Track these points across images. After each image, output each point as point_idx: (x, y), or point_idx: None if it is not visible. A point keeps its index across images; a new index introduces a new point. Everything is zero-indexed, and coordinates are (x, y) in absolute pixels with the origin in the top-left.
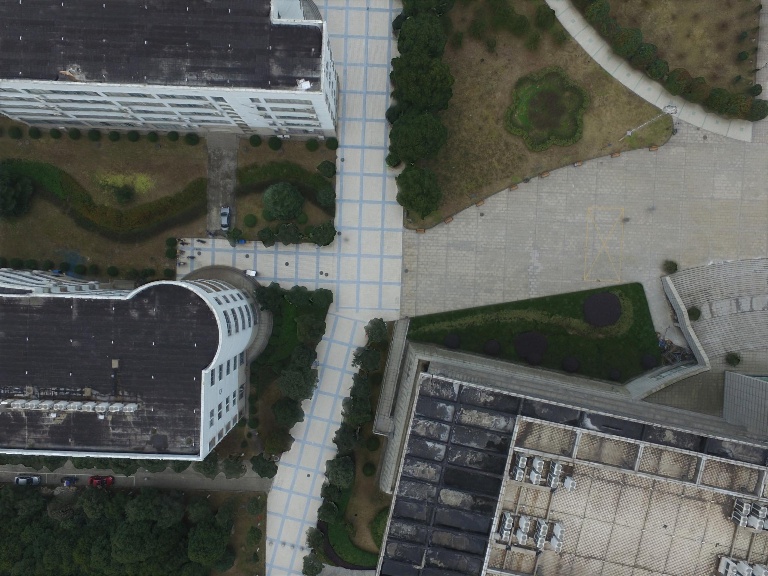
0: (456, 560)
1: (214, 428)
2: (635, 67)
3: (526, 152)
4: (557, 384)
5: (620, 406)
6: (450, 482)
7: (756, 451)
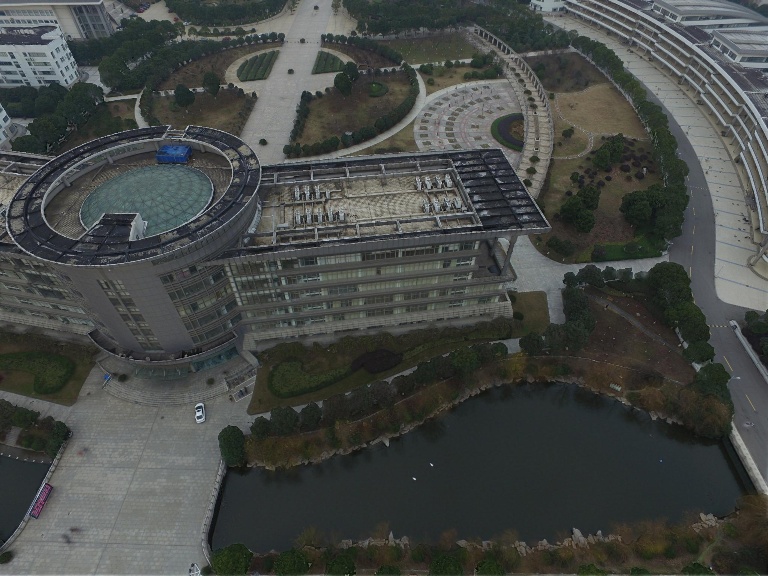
0: None
1: None
2: None
3: None
4: None
5: None
6: None
7: None
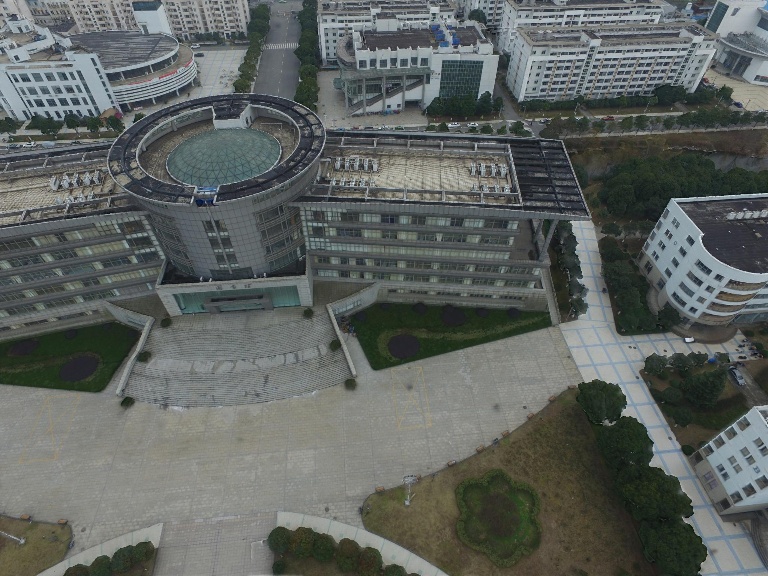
0: (526, 156)
1: (669, 222)
2: (420, 575)
3: (505, 469)
4: (439, 285)
5: (414, 258)
6: (545, 181)
7: None
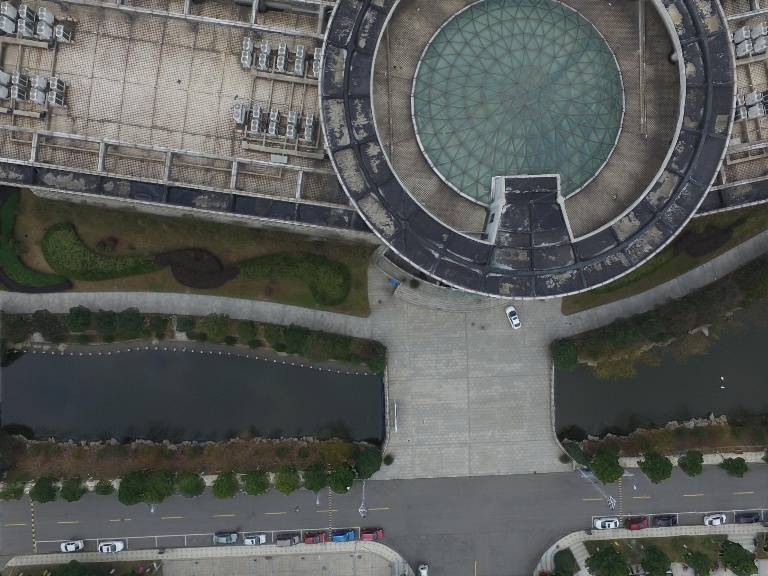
0: None
1: None
2: None
3: None
4: None
5: None
6: None
7: None
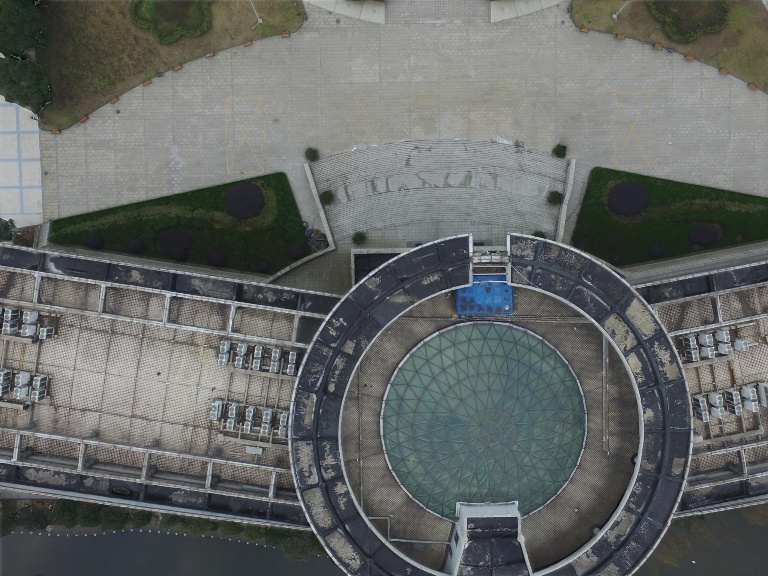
0: None
1: None
2: None
3: (157, 46)
4: None
5: None
6: None
7: (226, 287)
